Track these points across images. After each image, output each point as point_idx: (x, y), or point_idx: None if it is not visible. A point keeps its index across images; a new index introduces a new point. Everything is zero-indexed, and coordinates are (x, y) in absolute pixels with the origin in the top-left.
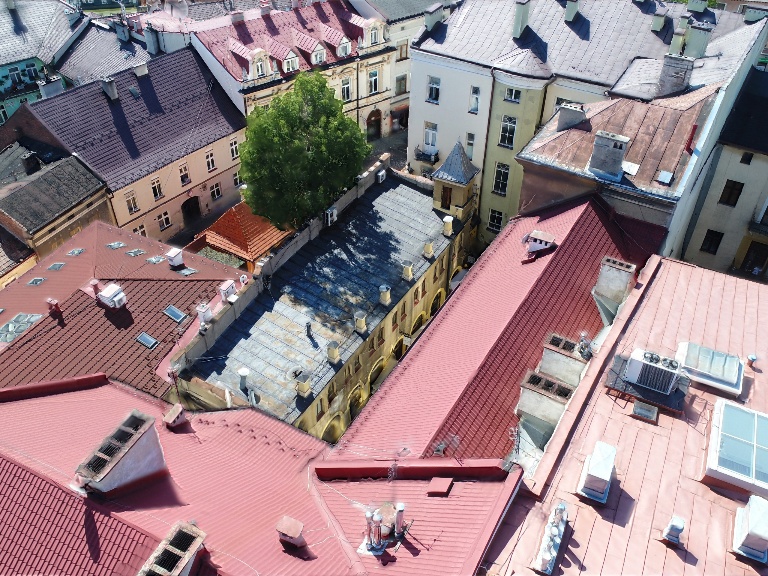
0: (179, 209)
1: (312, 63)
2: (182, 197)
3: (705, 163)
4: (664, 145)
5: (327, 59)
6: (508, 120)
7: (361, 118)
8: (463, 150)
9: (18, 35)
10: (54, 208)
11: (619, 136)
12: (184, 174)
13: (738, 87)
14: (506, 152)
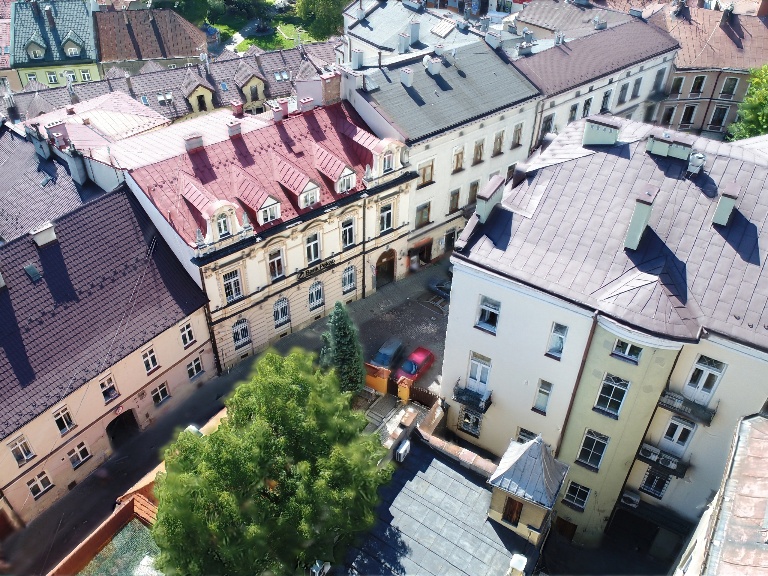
0: (102, 433)
1: (300, 207)
2: (106, 418)
3: None
4: None
5: (321, 198)
6: (614, 380)
7: (368, 263)
8: (545, 449)
9: None
10: None
11: None
12: (108, 388)
13: None
14: (606, 421)
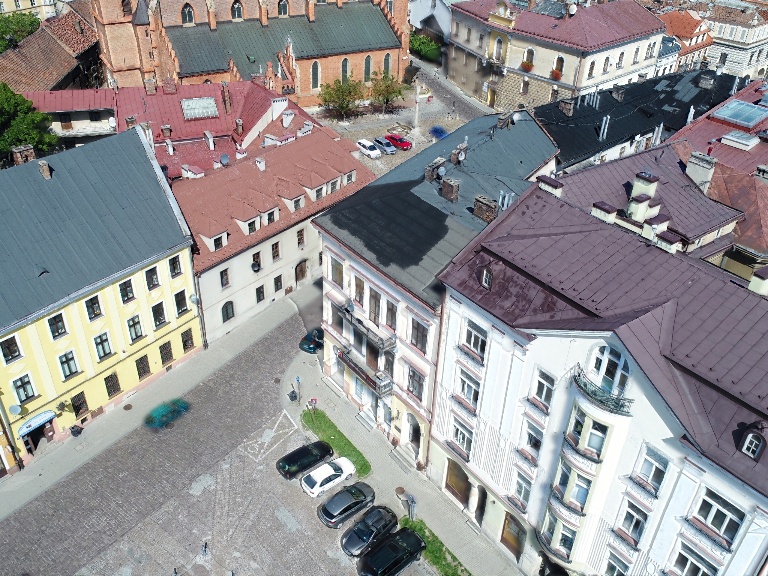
0: None
1: None
2: None
3: None
4: None
5: None
6: None
7: None
8: None
9: None
10: None
11: (767, 168)
12: None
13: None
14: None
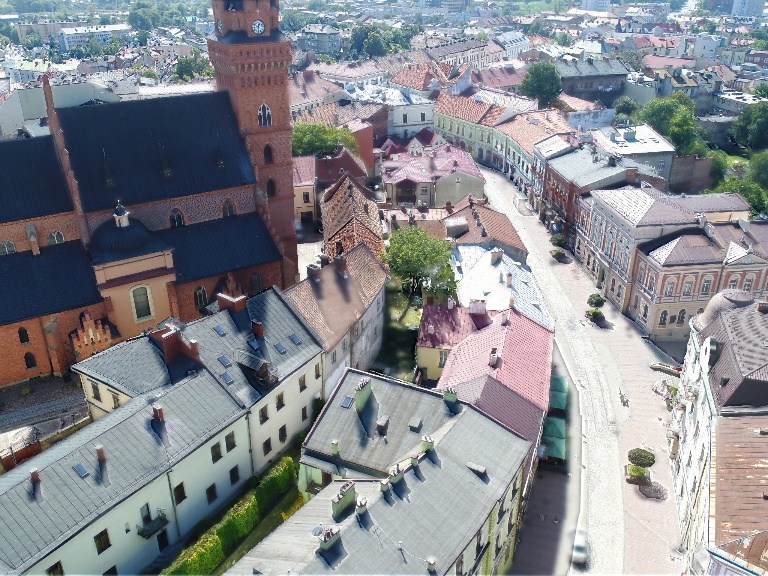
0: None
1: None
2: None
3: None
4: None
5: None
6: None
7: None
8: None
9: None
10: None
11: None
12: None
13: (71, 101)
14: None
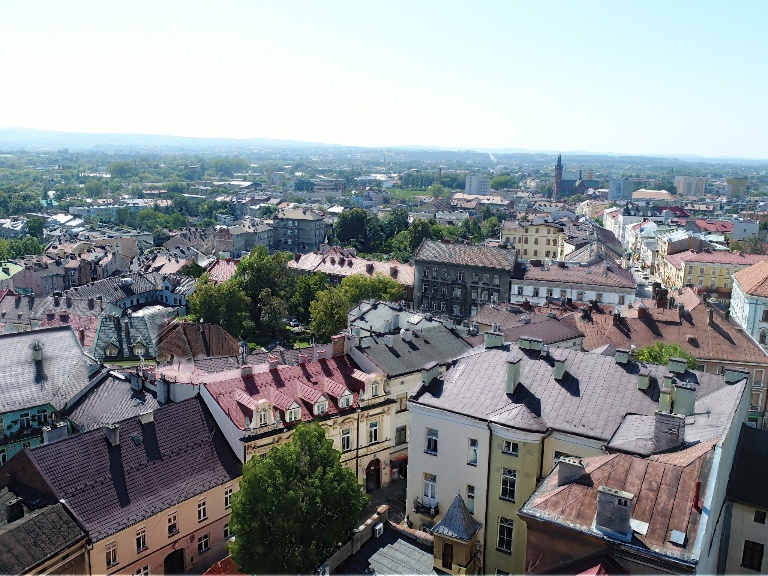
0: (161, 563)
1: (314, 413)
2: (166, 549)
3: (717, 522)
4: (670, 502)
5: (329, 410)
6: (508, 473)
7: (360, 467)
8: (463, 503)
9: (37, 383)
10: (26, 560)
11: (622, 492)
12: (172, 524)
13: (734, 443)
14: (508, 506)
